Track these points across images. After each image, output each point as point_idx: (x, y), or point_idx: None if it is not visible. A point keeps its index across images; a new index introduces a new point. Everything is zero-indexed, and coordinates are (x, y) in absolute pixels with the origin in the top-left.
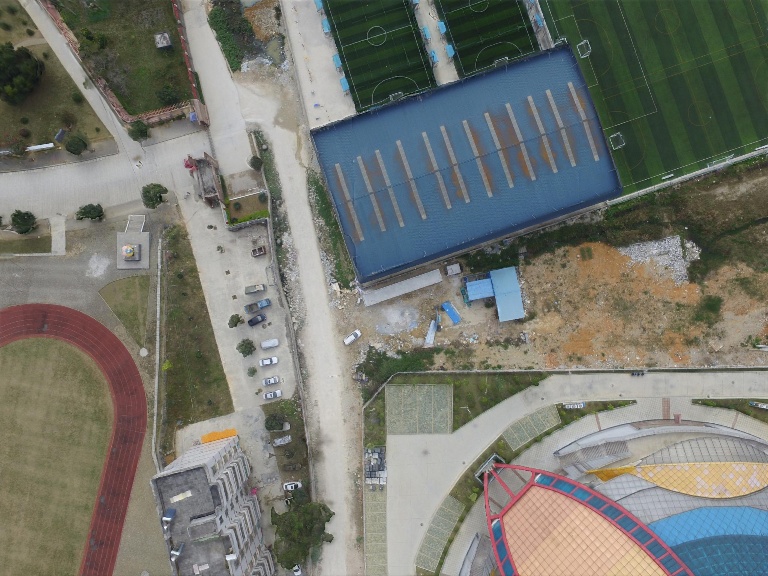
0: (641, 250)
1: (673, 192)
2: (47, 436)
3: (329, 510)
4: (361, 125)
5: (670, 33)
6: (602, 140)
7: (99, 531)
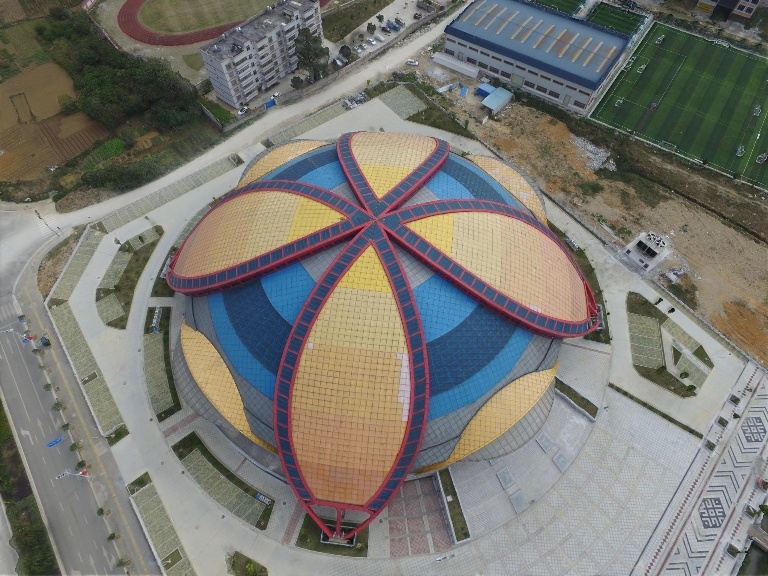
0: (583, 143)
1: (627, 138)
2: None
3: None
4: (511, 1)
5: (693, 95)
6: None
7: None
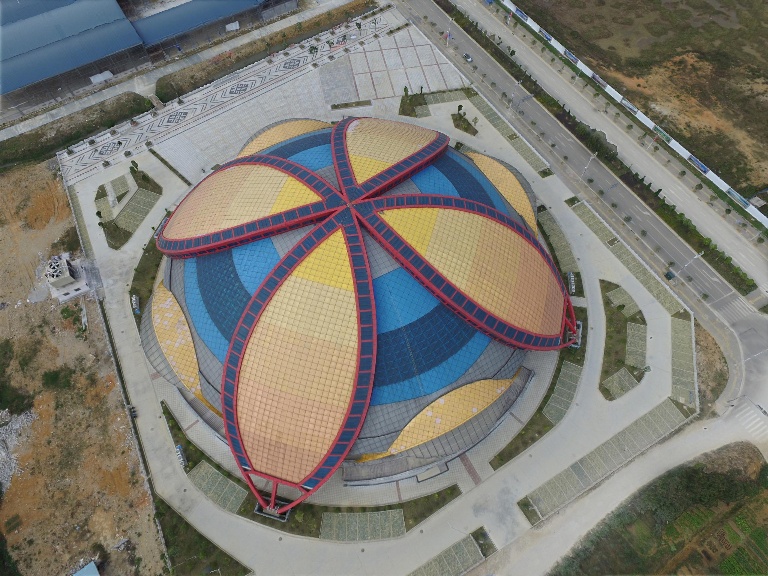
0: (3, 468)
1: None
2: None
3: None
4: None
5: None
6: None
7: None
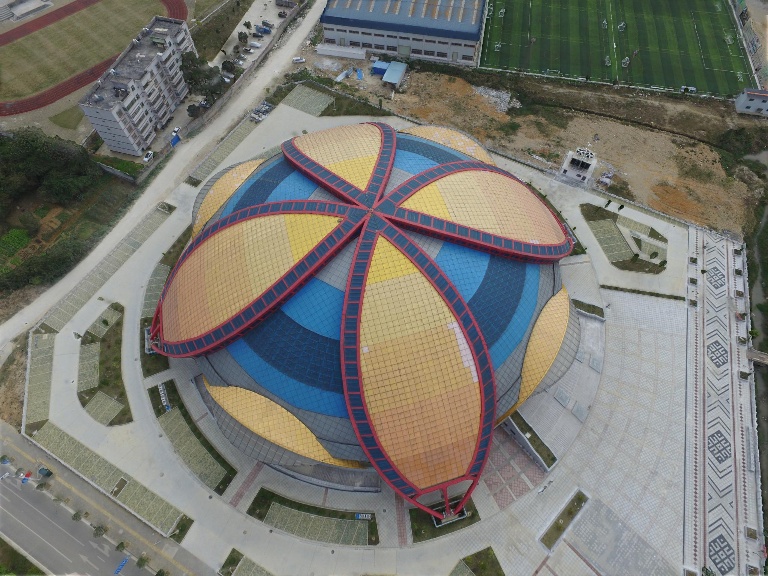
0: (485, 91)
1: (518, 76)
2: (117, 27)
3: (222, 86)
4: None
5: (552, 25)
6: (480, 18)
7: (97, 68)
